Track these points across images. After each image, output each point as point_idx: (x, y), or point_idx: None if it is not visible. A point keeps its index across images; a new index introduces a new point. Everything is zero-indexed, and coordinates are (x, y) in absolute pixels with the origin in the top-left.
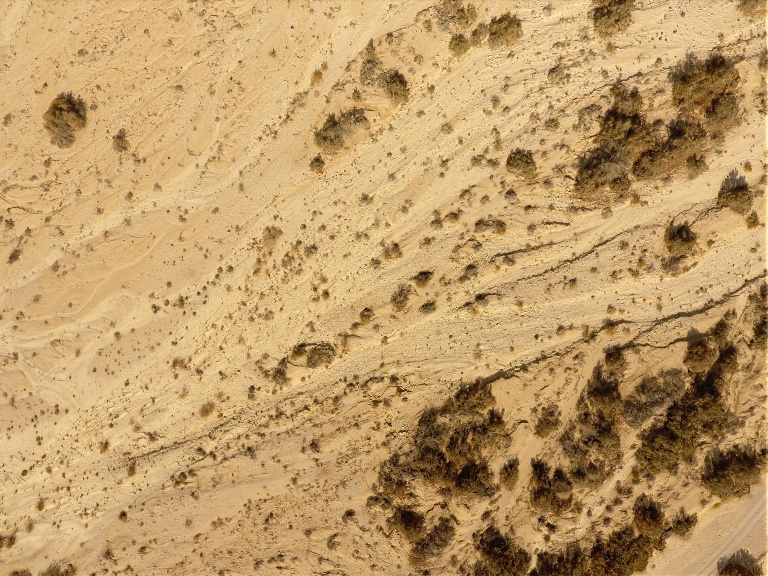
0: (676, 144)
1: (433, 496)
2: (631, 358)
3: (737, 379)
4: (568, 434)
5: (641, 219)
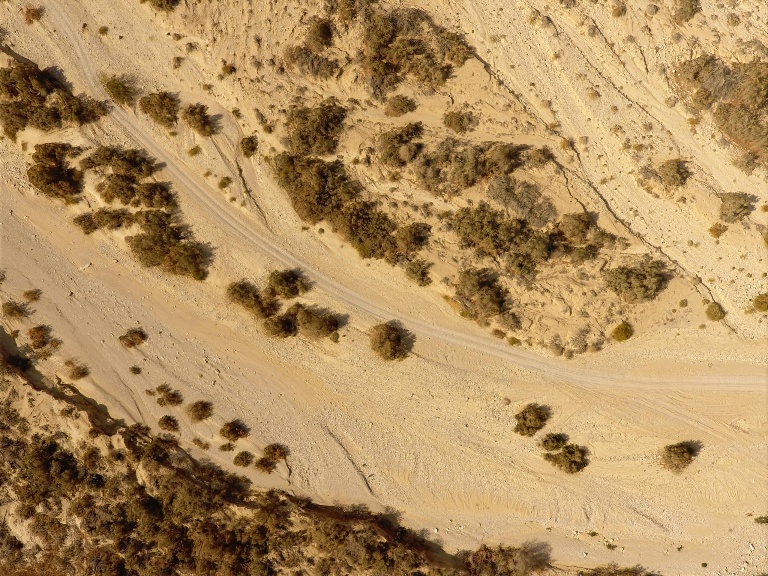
0: (765, 125)
1: (353, 47)
2: (549, 168)
3: (568, 270)
4: (457, 141)
5: (678, 134)
